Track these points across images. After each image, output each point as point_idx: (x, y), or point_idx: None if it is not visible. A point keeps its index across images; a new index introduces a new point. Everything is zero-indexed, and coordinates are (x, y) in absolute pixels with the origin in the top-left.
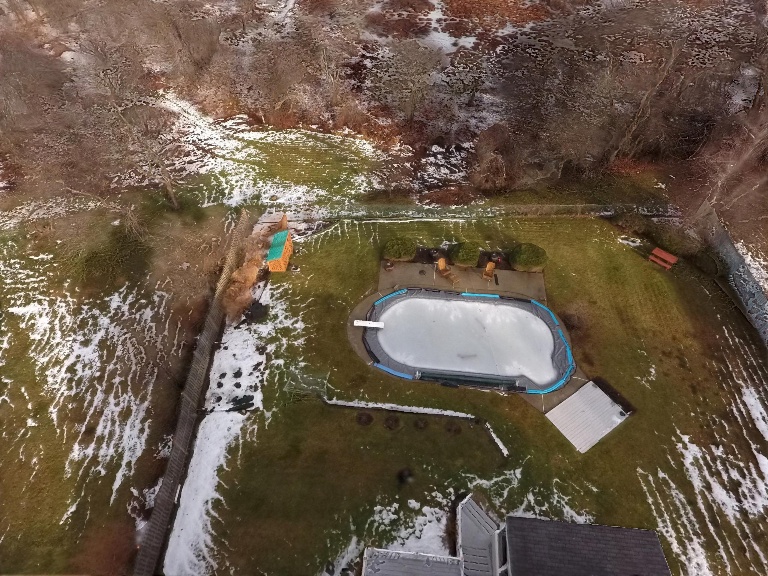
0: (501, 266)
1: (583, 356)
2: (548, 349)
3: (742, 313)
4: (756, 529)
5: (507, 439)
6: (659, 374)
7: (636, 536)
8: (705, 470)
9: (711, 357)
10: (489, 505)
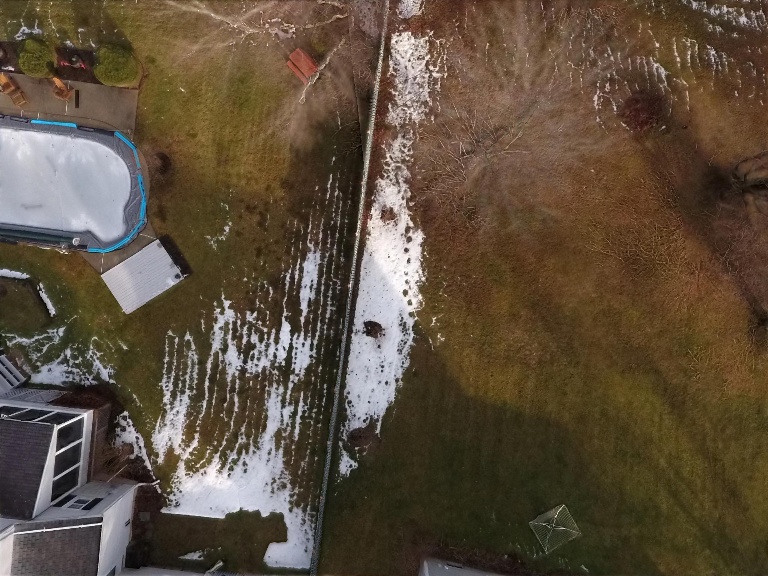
0: (86, 76)
1: (157, 210)
2: (122, 200)
3: (362, 156)
4: (245, 385)
5: (57, 300)
6: (231, 234)
7: (35, 430)
8: (229, 334)
9: (296, 215)
10: (24, 360)
